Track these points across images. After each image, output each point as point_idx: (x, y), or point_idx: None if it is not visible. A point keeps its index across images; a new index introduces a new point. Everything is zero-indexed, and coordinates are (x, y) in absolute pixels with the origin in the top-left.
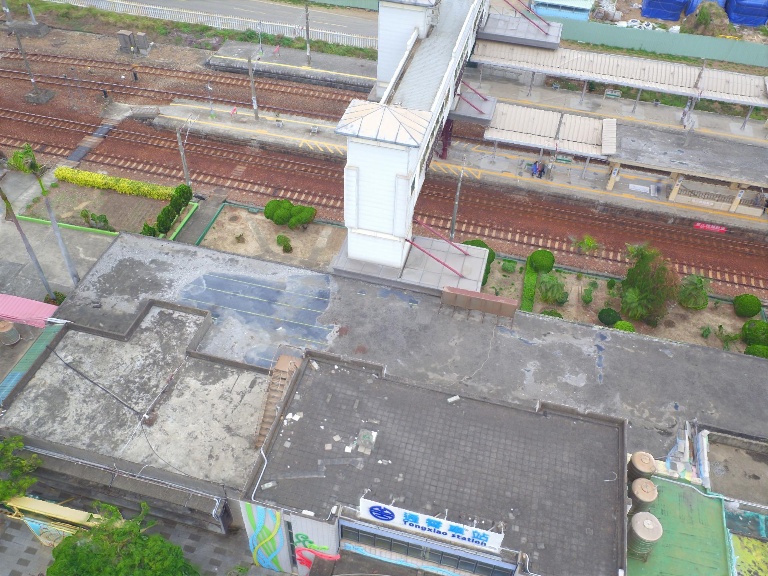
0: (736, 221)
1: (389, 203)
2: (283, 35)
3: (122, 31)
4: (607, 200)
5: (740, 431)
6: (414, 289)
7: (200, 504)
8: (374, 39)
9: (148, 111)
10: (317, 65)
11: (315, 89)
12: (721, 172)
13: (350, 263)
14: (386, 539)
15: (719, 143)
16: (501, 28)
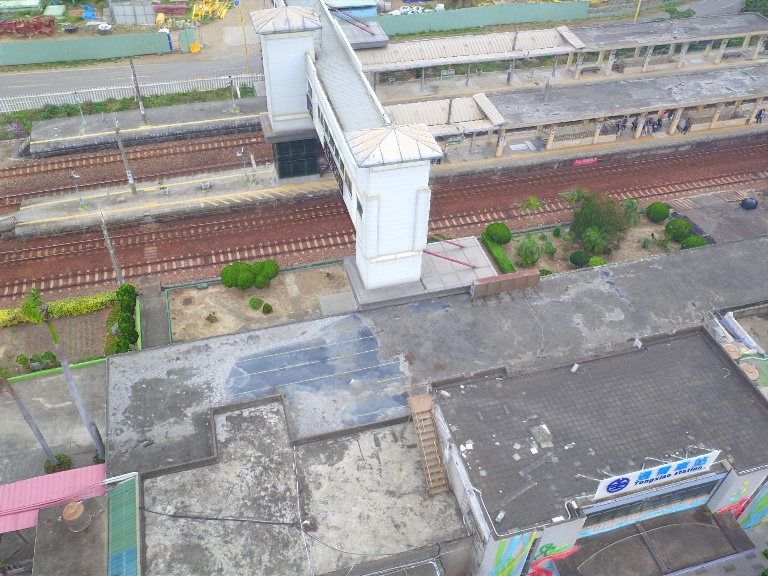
0: (603, 150)
1: (409, 221)
2: (90, 101)
3: None
4: (504, 165)
5: (745, 303)
6: (441, 295)
7: (420, 575)
8: (195, 81)
9: (0, 224)
10: (155, 122)
11: (166, 146)
12: (586, 112)
13: (372, 294)
14: (612, 509)
15: (567, 90)
16: None
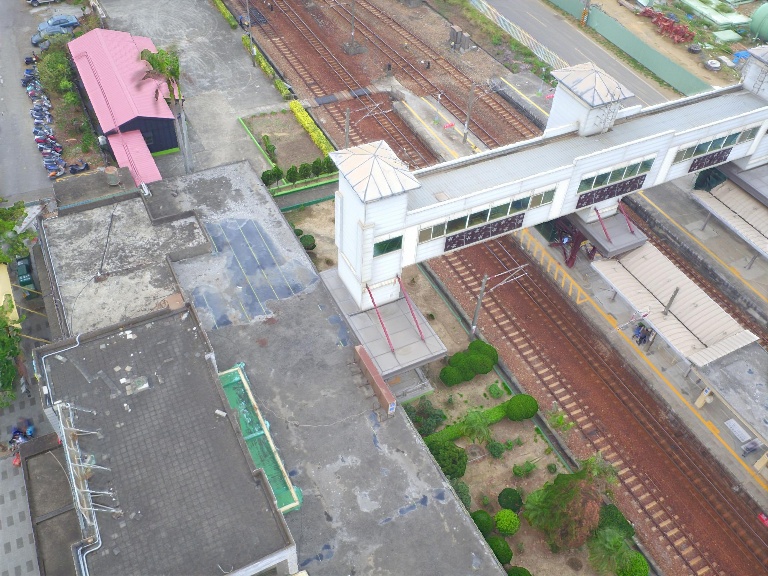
0: None
1: (356, 243)
2: None
3: (456, 26)
4: (680, 413)
5: None
6: (353, 333)
7: None
8: None
9: (399, 94)
10: None
11: None
12: None
13: (334, 279)
14: None
15: None
16: (763, 181)
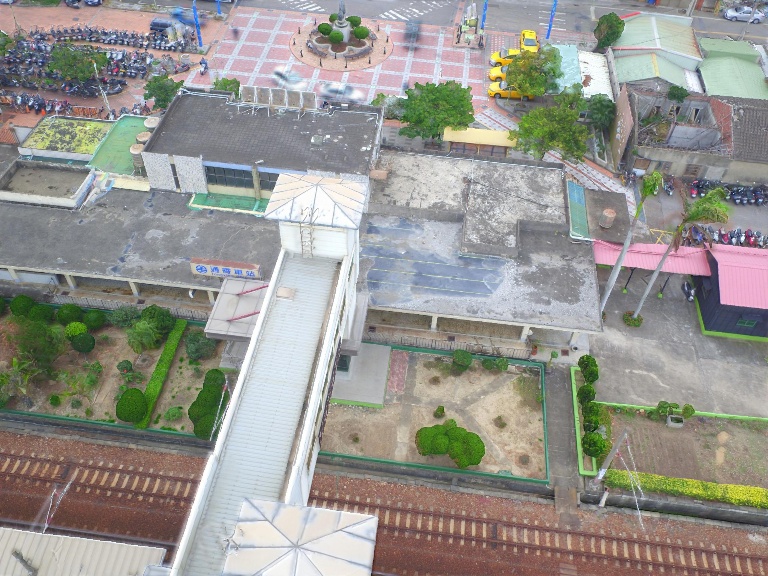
0: None
1: None
2: None
3: None
4: None
5: (42, 207)
6: None
7: None
8: None
9: None
10: None
11: None
12: None
13: None
14: None
15: None
16: None
